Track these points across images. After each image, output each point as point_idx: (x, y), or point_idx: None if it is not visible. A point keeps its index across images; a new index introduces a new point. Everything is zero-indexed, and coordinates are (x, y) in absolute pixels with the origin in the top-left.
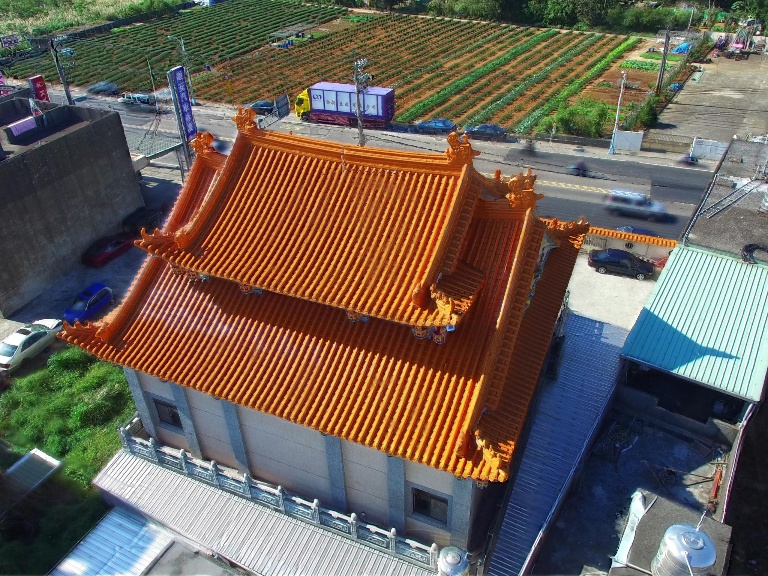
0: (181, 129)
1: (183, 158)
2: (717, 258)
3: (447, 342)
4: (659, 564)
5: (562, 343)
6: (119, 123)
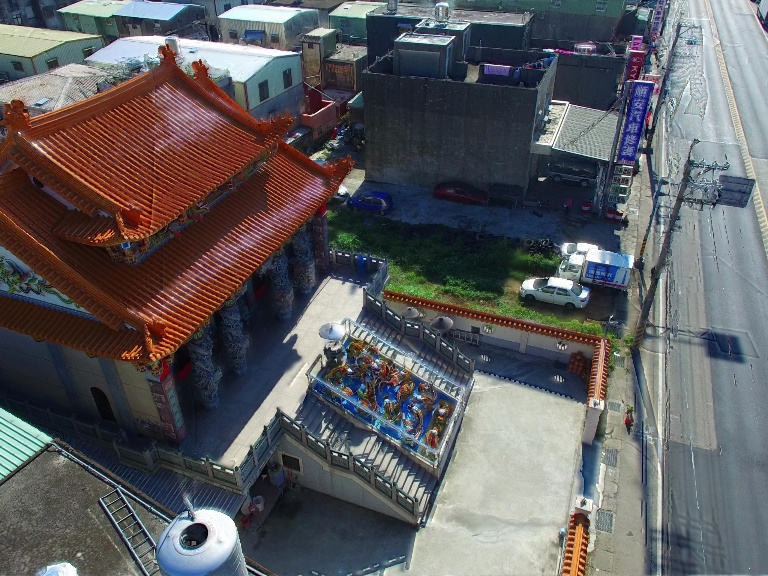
0: (614, 146)
1: (604, 176)
2: None
3: None
4: None
5: (139, 449)
6: (534, 101)
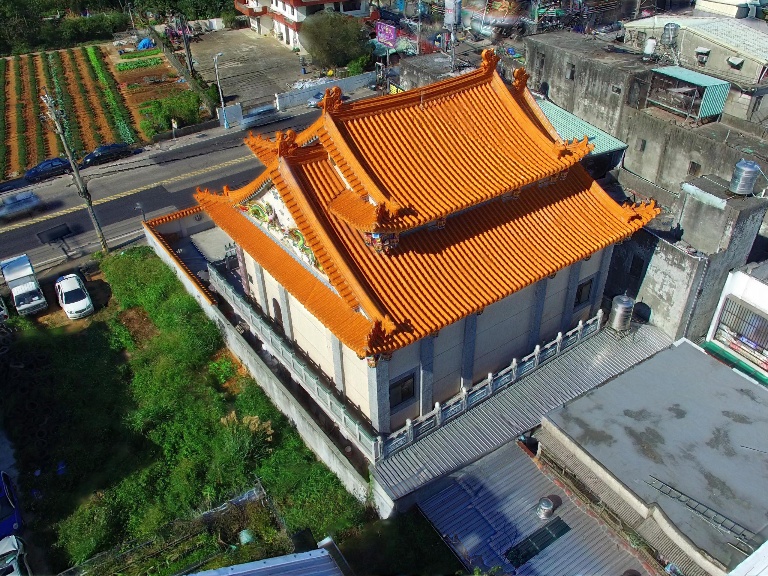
0: None
1: None
2: None
3: (558, 180)
4: (738, 187)
5: None
6: None
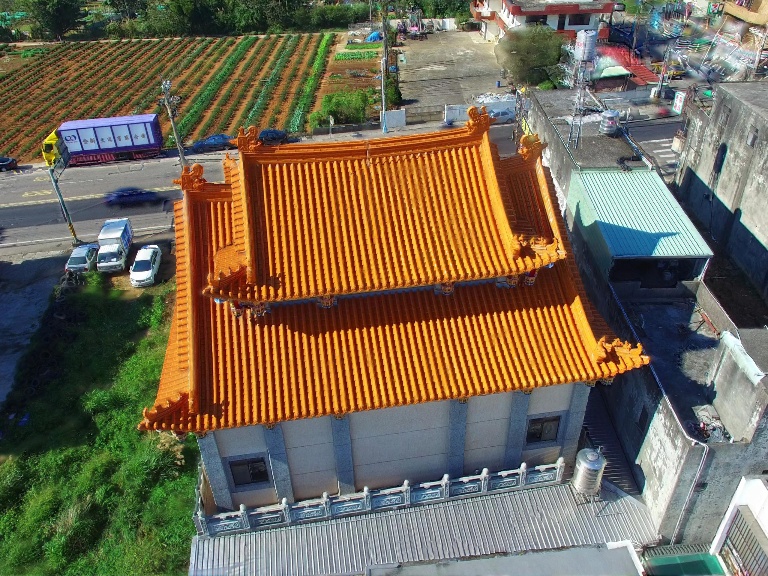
0: None
1: None
2: (607, 174)
3: None
4: None
5: None
6: None
